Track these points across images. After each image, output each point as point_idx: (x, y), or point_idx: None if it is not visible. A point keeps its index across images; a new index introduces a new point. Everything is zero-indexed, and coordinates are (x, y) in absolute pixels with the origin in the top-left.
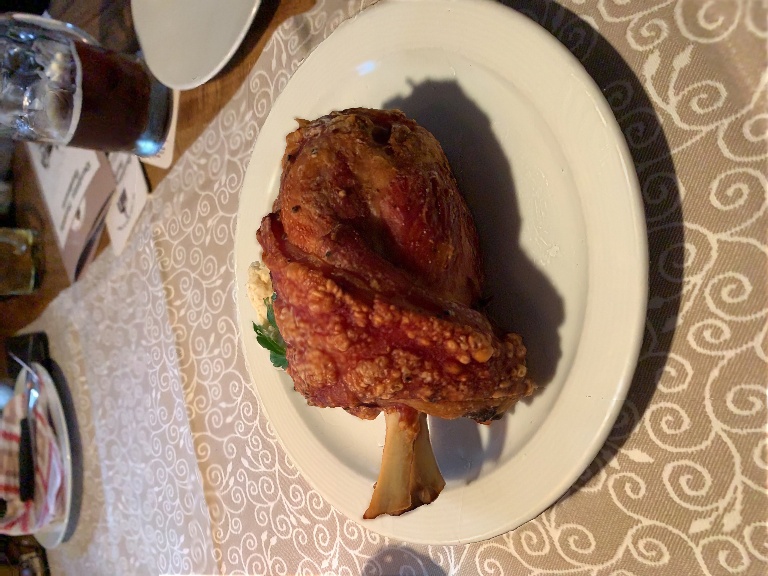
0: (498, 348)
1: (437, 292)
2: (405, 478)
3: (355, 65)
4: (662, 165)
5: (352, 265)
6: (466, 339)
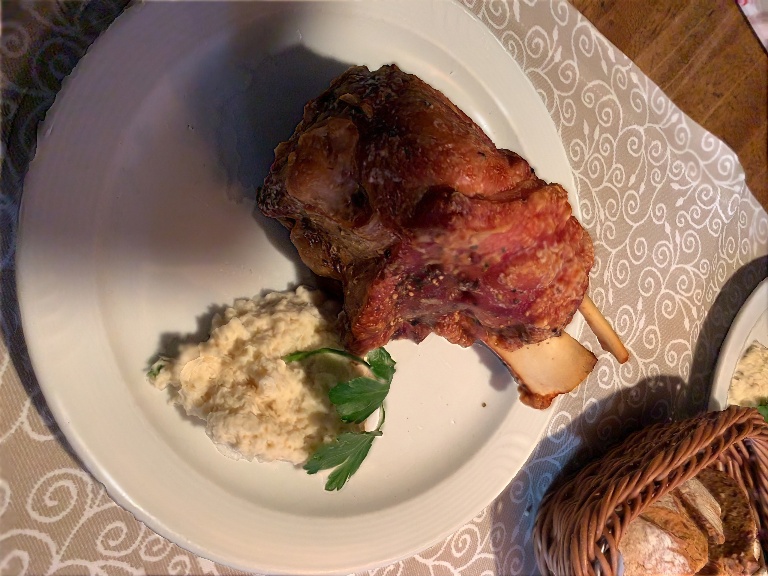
0: None
1: None
2: None
3: (168, 69)
4: None
5: None
6: None
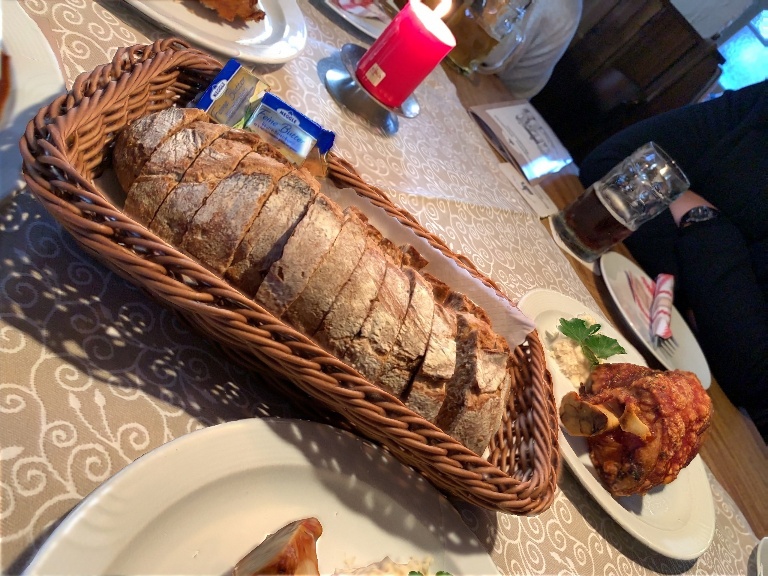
0: None
1: None
2: None
3: None
4: None
5: (703, 426)
6: None
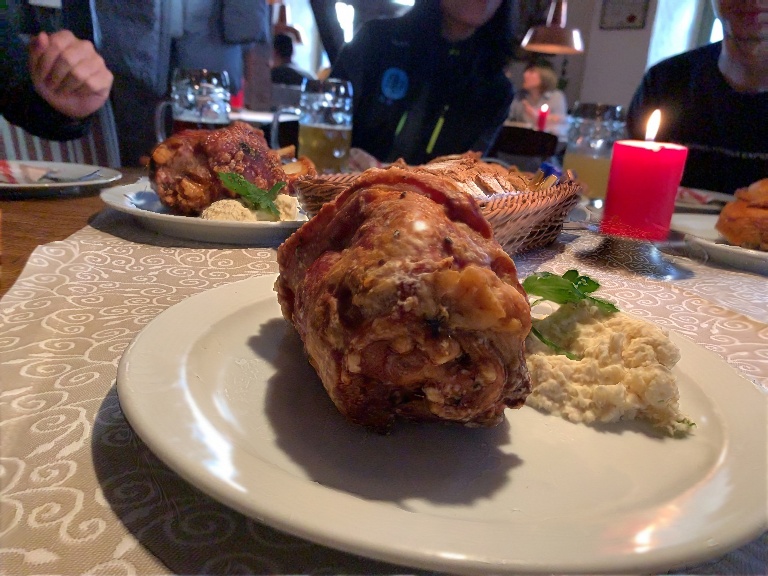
0: None
1: None
2: None
3: None
4: None
5: None
6: None
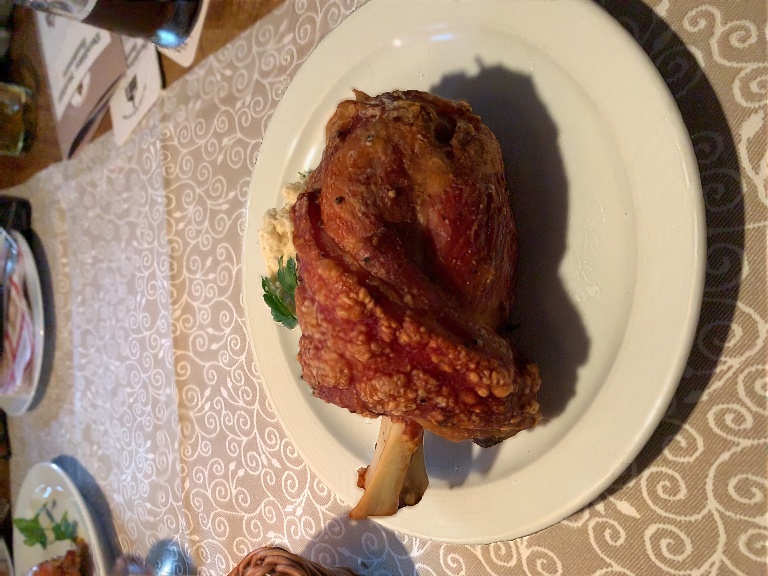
0: (517, 383)
1: (468, 314)
2: (397, 487)
3: (422, 25)
4: (732, 237)
5: (389, 276)
6: (490, 374)
